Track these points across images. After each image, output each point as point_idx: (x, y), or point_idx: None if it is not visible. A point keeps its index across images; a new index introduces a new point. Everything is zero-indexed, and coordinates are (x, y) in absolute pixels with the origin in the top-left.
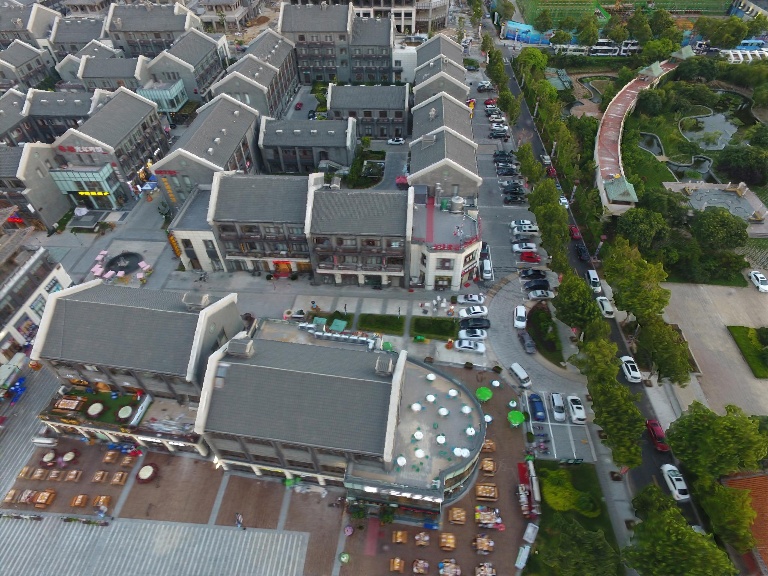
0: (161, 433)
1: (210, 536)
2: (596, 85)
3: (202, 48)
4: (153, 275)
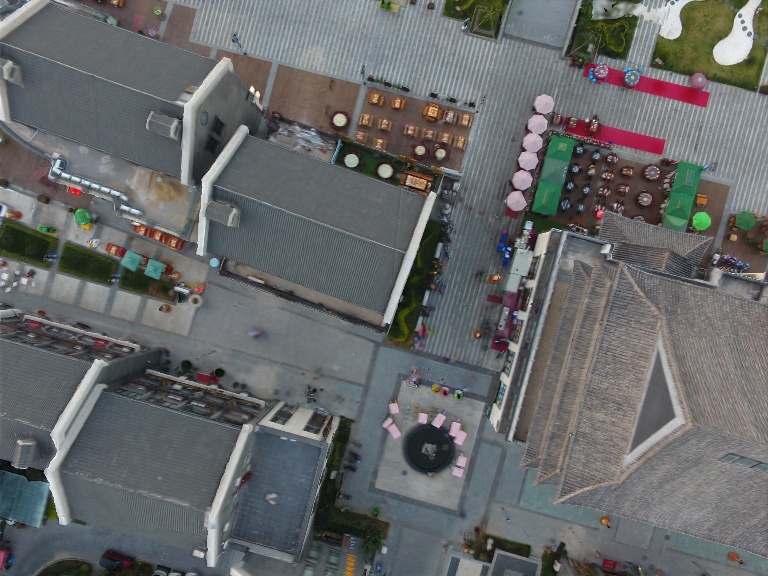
0: (311, 130)
1: (275, 53)
2: None
3: None
4: (383, 416)
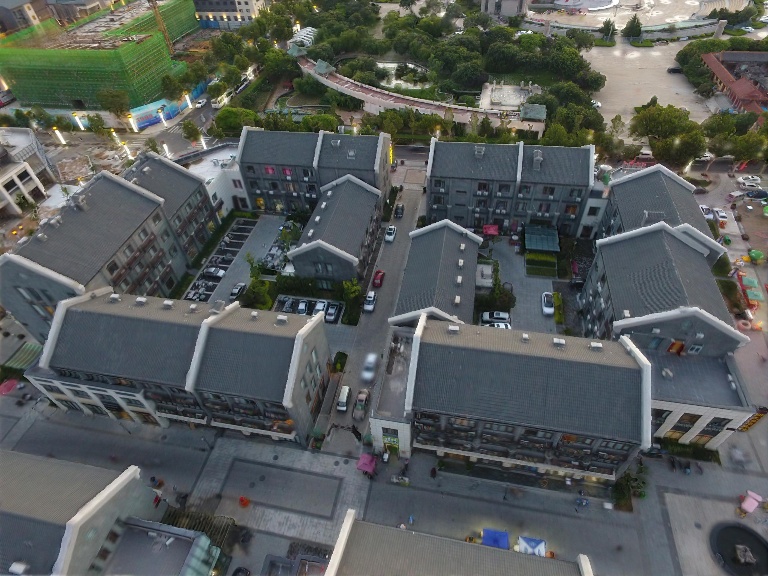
0: None
1: None
2: (297, 104)
3: (4, 464)
4: None
